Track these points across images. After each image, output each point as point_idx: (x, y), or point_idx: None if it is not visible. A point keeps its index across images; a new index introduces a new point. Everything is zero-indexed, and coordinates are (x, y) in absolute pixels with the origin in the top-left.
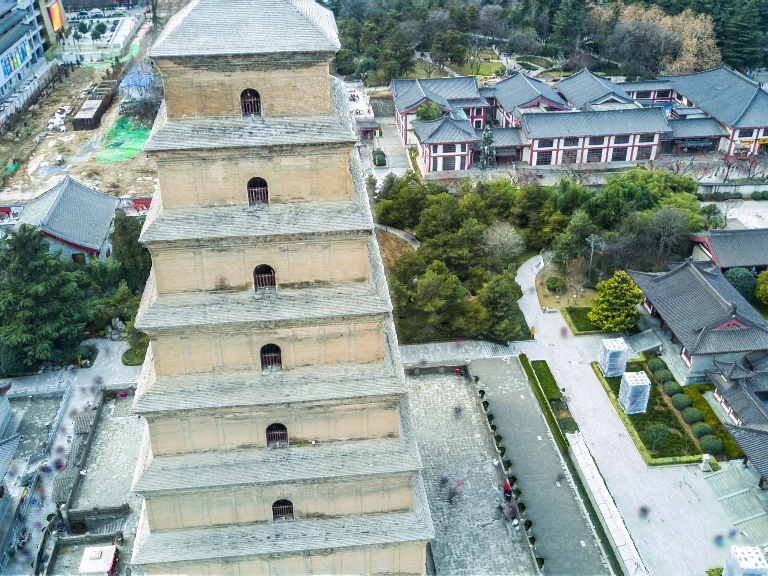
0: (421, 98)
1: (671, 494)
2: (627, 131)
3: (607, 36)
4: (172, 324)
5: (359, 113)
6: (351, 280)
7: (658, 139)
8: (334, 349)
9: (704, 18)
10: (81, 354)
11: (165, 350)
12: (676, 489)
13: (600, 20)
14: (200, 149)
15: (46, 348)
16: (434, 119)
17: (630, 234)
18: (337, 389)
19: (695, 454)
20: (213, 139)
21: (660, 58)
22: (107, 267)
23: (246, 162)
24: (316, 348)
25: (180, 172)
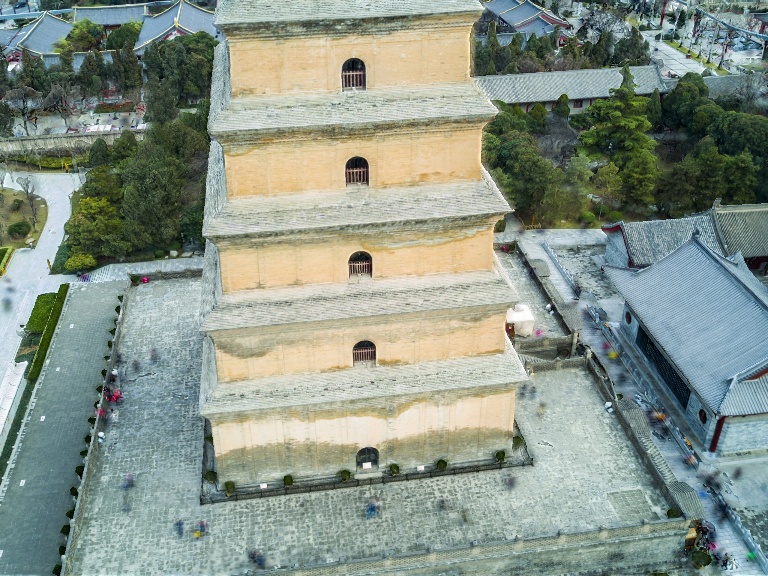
0: None
1: None
2: None
3: None
4: None
5: None
6: None
7: None
8: None
9: None
10: None
11: None
12: None
13: None
14: None
15: None
16: None
17: None
18: None
19: None
20: None
21: None
22: None
23: None
24: None
25: None
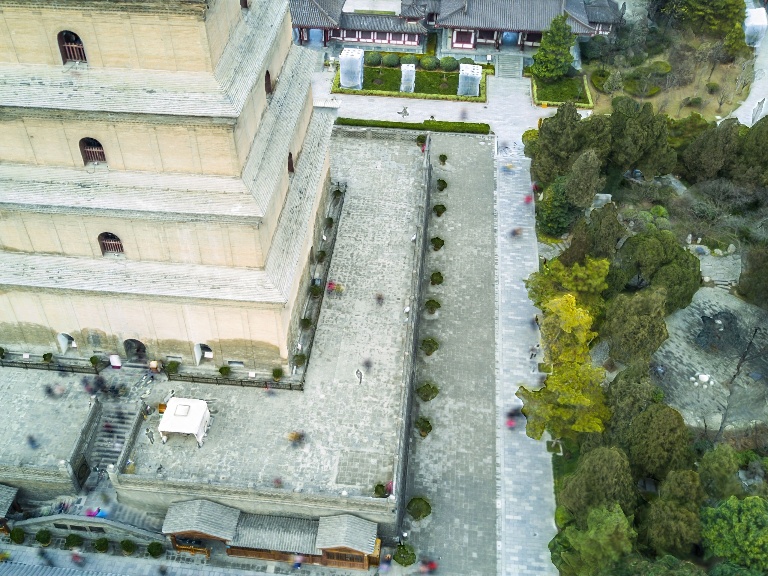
0: None
1: None
2: None
3: None
4: None
5: None
6: None
7: None
8: None
9: None
10: None
11: None
12: None
13: None
14: None
15: None
16: None
17: None
18: (279, 2)
19: None
20: None
21: None
22: None
23: None
24: None
25: None
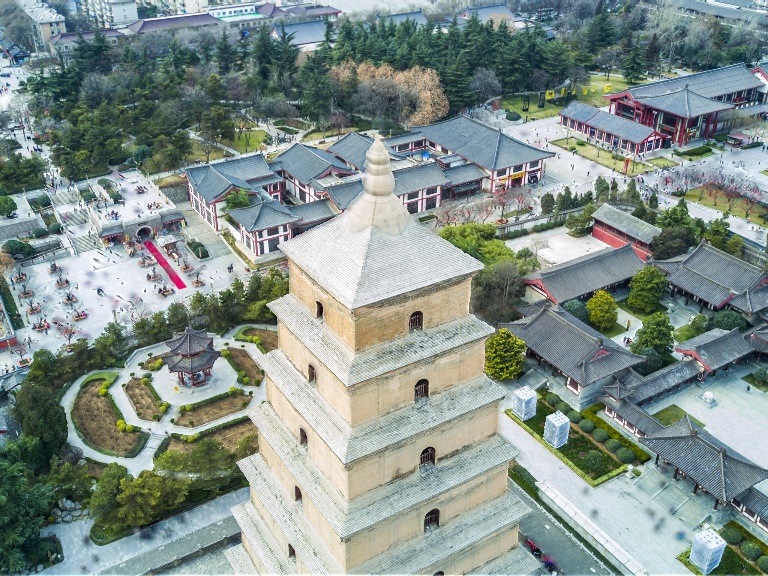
0: (228, 186)
1: (621, 505)
2: (417, 188)
3: (352, 95)
4: (370, 523)
5: (159, 207)
6: (486, 437)
7: (440, 189)
8: (476, 496)
9: (431, 72)
10: (49, 550)
11: (355, 546)
12: (622, 500)
13: (339, 80)
14: (388, 372)
15: (18, 558)
16: (250, 205)
17: (477, 288)
18: (484, 528)
19: (619, 467)
20: (397, 361)
21: (400, 109)
22: (27, 447)
23: (416, 370)
24: (464, 500)
25: (367, 394)
